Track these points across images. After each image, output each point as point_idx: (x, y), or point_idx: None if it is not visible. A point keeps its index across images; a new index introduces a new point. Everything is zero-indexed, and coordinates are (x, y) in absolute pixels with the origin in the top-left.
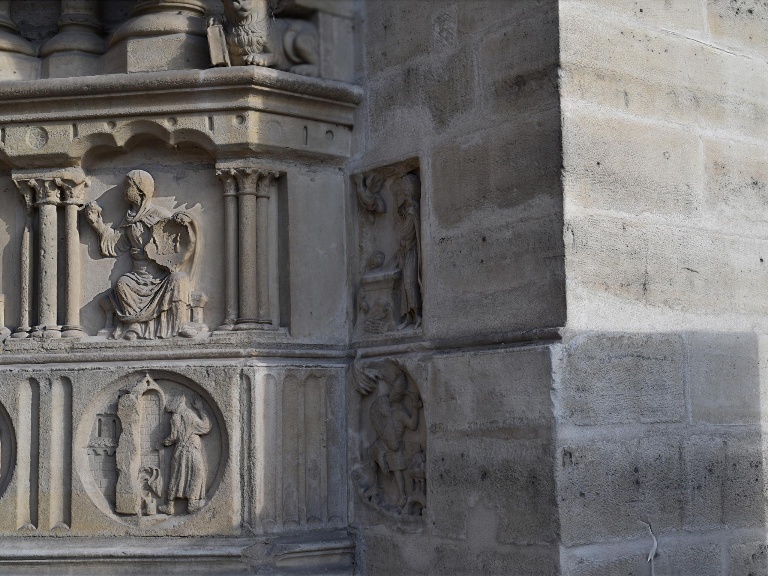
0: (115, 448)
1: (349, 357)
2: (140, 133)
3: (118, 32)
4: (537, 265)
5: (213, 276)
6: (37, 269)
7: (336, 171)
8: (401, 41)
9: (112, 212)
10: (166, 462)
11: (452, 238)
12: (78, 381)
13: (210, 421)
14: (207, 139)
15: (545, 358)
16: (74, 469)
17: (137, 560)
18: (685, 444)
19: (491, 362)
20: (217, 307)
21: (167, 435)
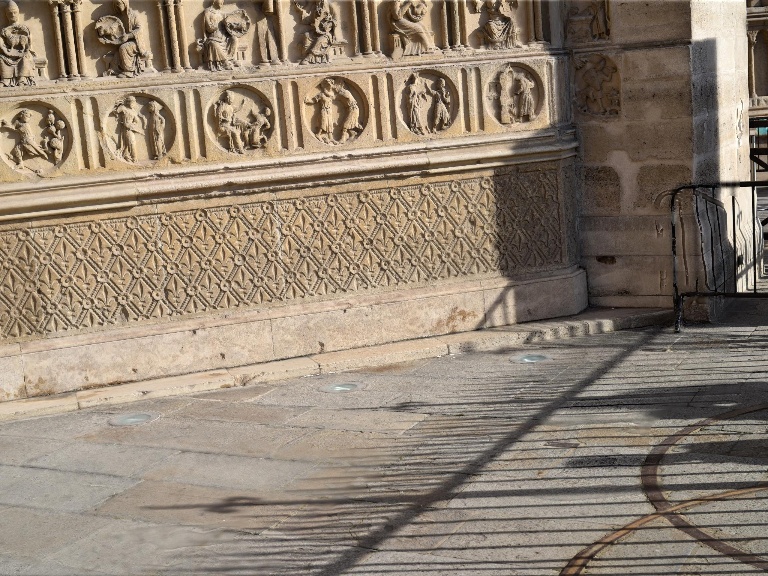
0: (499, 96)
1: (566, 53)
2: None
3: None
4: (677, 16)
5: (522, 20)
6: (451, 19)
7: None
8: None
9: None
10: (517, 101)
11: (628, 3)
12: (483, 69)
13: (534, 83)
14: None
15: (688, 50)
16: (484, 106)
17: (515, 141)
18: (707, 80)
19: (659, 53)
20: (524, 34)
21: (518, 90)
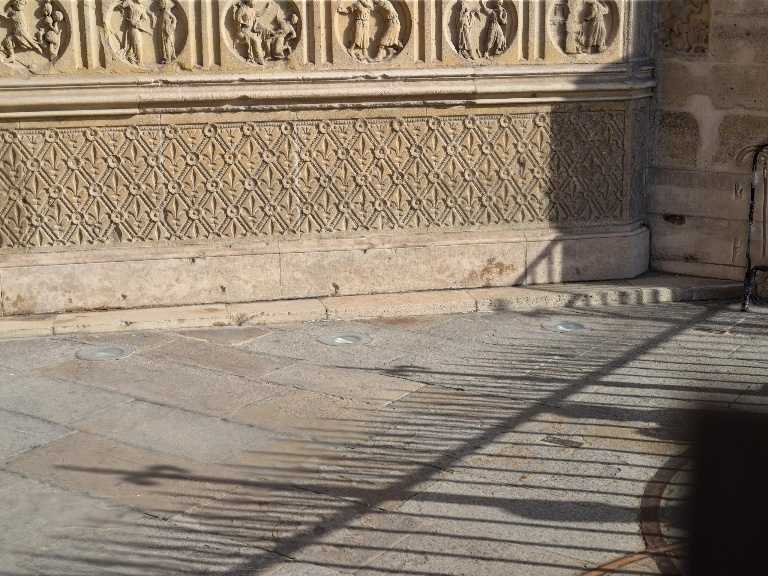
0: (566, 21)
1: None
2: None
3: None
4: None
5: None
6: None
7: None
8: None
9: None
10: (586, 28)
11: None
12: None
13: (609, 8)
14: None
15: None
16: (546, 31)
17: (578, 74)
18: None
19: None
20: None
21: (588, 15)
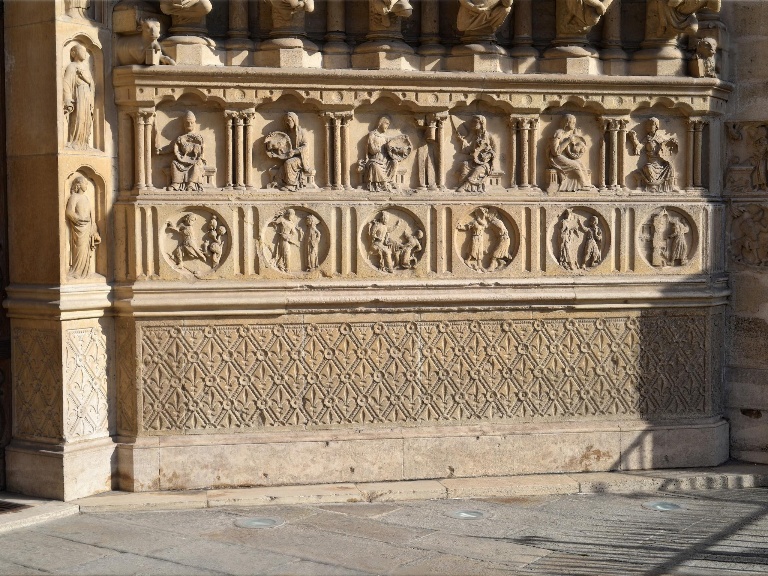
0: (652, 238)
1: (724, 201)
2: (659, 102)
3: (651, 55)
4: None
5: (681, 166)
6: (609, 159)
7: (718, 120)
8: (763, 69)
9: (639, 135)
10: (670, 244)
11: None
12: (637, 210)
13: (689, 228)
14: (690, 107)
15: None
16: (636, 247)
17: (664, 284)
18: None
19: None
20: (682, 179)
21: (671, 233)
